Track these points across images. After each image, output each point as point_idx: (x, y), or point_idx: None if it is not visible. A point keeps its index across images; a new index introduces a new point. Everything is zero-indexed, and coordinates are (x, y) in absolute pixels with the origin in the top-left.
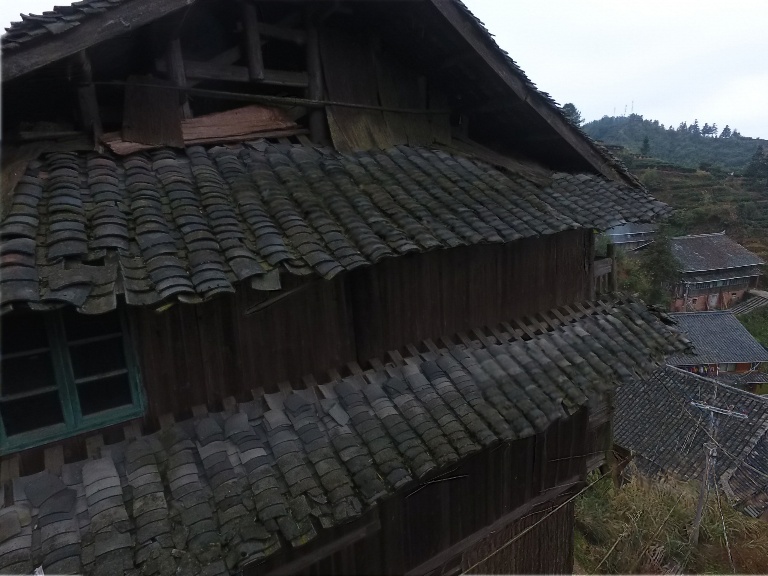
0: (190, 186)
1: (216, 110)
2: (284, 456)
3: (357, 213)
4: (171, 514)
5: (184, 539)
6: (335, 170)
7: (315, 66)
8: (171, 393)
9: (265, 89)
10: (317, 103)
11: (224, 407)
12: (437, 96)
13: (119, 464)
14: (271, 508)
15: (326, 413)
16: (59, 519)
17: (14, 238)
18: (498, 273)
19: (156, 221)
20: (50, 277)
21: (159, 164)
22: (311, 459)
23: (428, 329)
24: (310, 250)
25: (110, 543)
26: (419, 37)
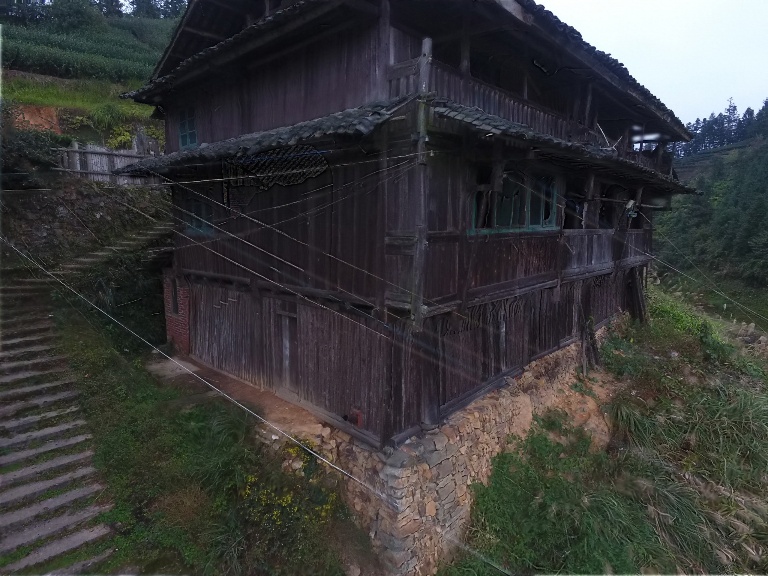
0: None
1: None
2: None
3: None
4: None
5: None
6: None
7: None
8: None
9: None
10: None
11: None
12: None
13: None
14: None
15: None
16: None
17: None
18: (302, 85)
19: None
20: None
21: None
22: None
23: None
24: None
25: None
26: None
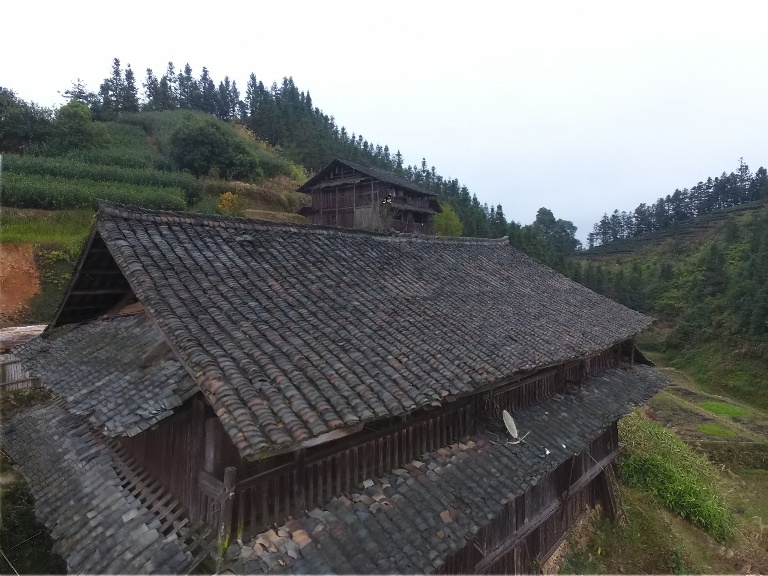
0: None
1: None
2: None
3: None
4: None
5: None
6: None
7: None
8: None
9: None
10: None
11: None
12: None
13: None
14: None
15: None
16: None
17: None
18: None
19: None
20: None
21: None
22: None
23: None
24: None
25: None
26: None
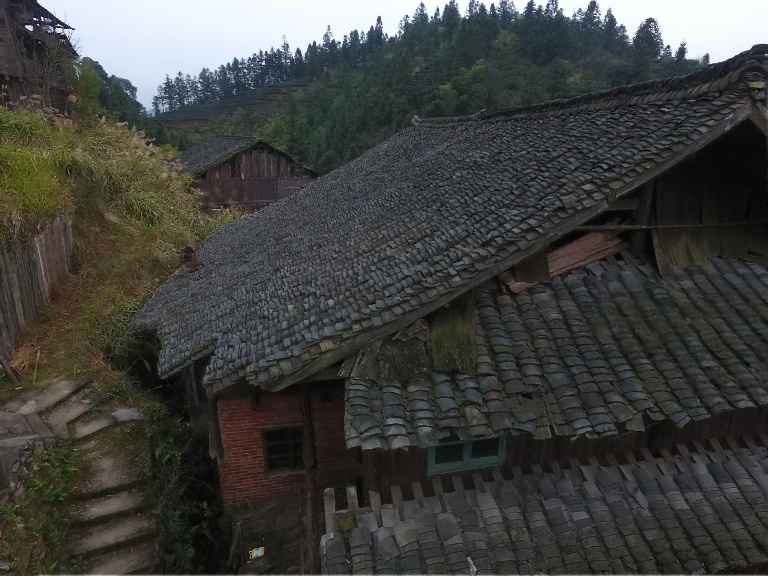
0: (562, 322)
1: (567, 241)
2: (602, 523)
3: (689, 353)
4: (533, 545)
5: (547, 567)
6: (664, 301)
7: (648, 194)
8: (520, 453)
9: (604, 218)
10: (646, 228)
11: (552, 470)
12: (761, 208)
13: (496, 499)
14: (599, 562)
15: (631, 495)
16: (474, 530)
17: (487, 376)
18: None
19: (556, 363)
20: (513, 410)
21: (538, 299)
22: (622, 531)
23: (715, 429)
24: (664, 400)
25: (504, 555)
26: (764, 176)
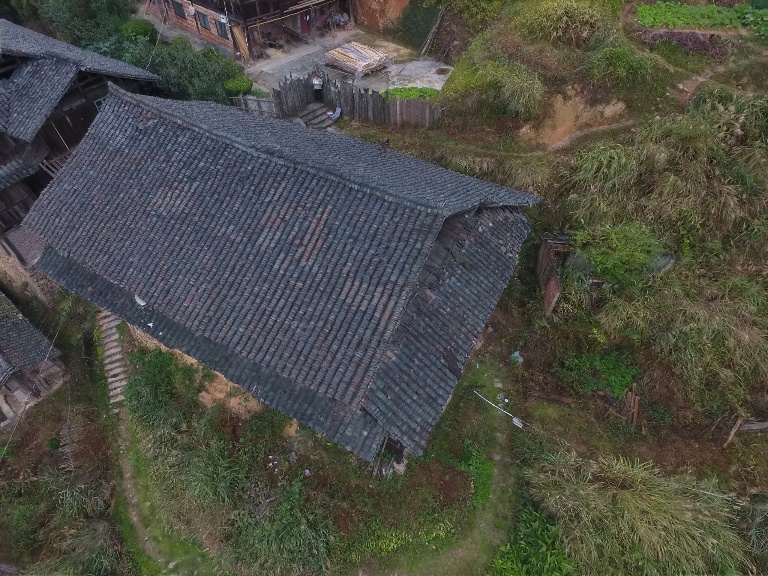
0: None
1: None
2: None
3: None
4: None
5: None
6: None
7: None
8: None
9: None
10: None
11: None
12: None
13: None
14: None
15: None
16: None
17: None
18: None
19: None
20: None
21: None
22: None
23: None
24: None
25: None
26: None
